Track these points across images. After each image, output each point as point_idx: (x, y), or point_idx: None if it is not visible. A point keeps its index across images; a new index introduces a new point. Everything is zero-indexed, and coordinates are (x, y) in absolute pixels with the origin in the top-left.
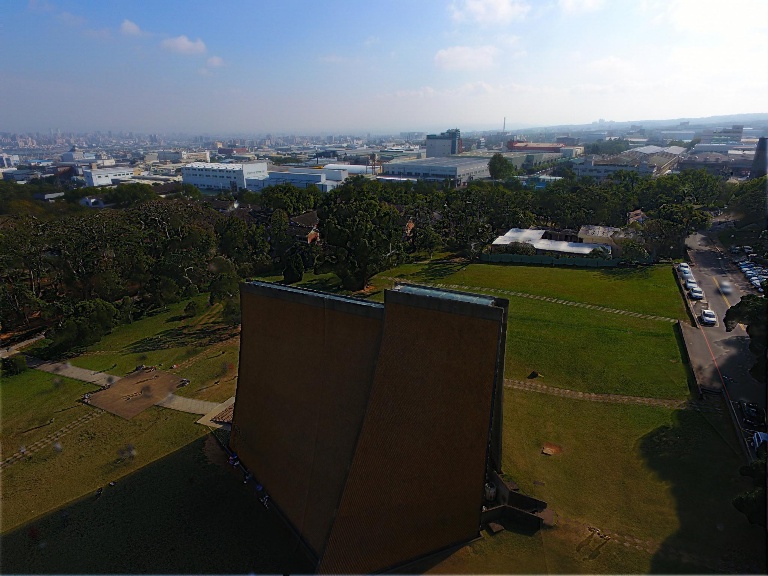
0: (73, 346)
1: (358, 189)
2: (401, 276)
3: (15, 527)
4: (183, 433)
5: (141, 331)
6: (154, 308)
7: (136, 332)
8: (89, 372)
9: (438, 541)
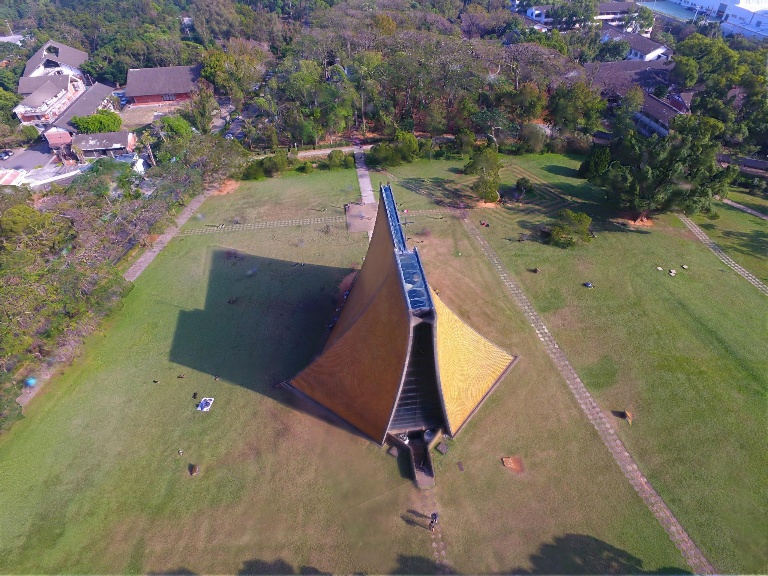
0: None
1: None
2: (708, 227)
3: (263, 257)
4: (352, 260)
5: (426, 170)
6: (456, 153)
7: (423, 169)
8: (369, 187)
9: (356, 422)
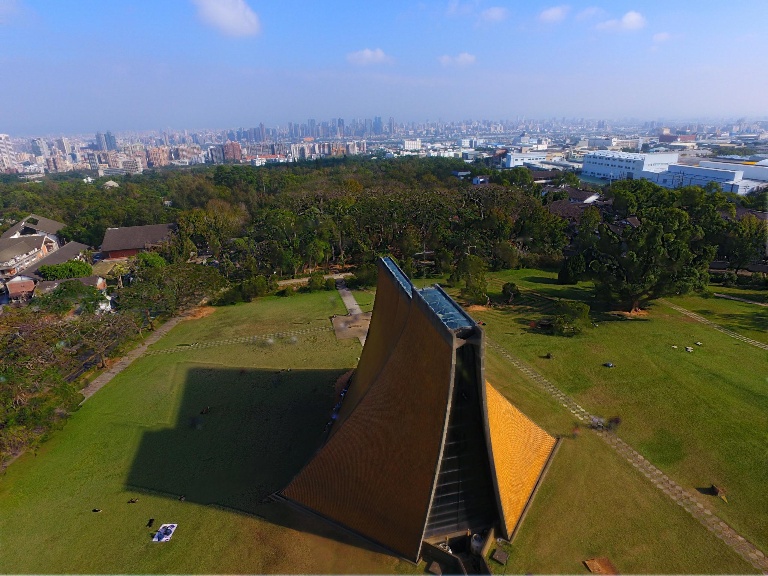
0: (367, 284)
1: (709, 193)
2: (702, 312)
3: (242, 367)
4: (345, 361)
5: None
6: (435, 273)
7: None
8: (354, 303)
9: (376, 533)
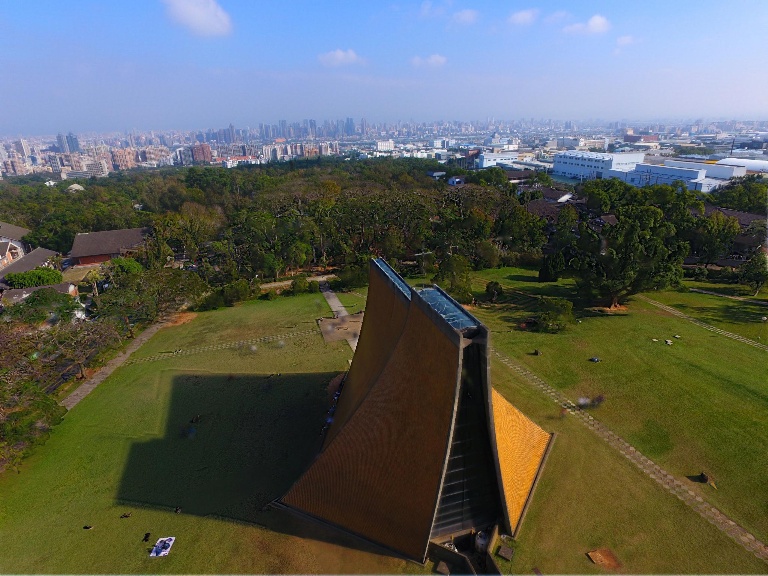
0: (350, 285)
1: (679, 191)
2: (677, 306)
3: (230, 374)
4: (335, 364)
5: None
6: (418, 273)
7: None
8: (339, 305)
9: (382, 536)
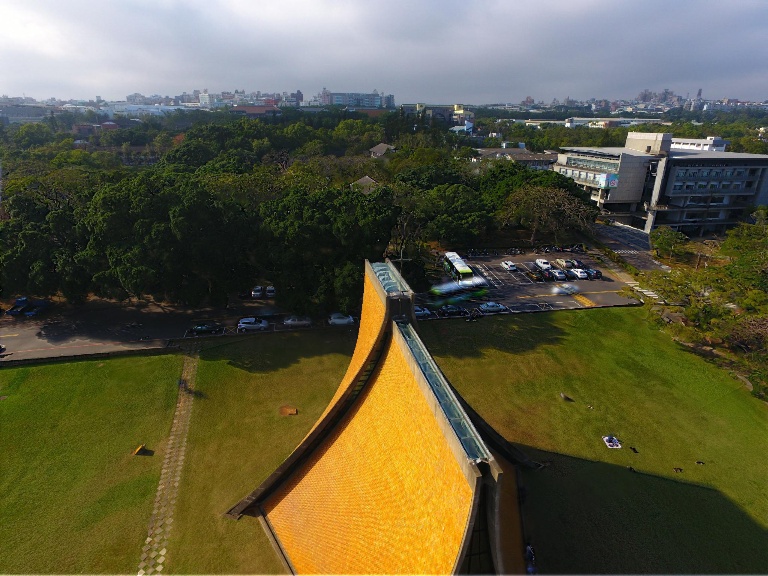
0: None
1: None
2: None
3: None
4: None
5: None
6: None
7: None
8: None
9: None
